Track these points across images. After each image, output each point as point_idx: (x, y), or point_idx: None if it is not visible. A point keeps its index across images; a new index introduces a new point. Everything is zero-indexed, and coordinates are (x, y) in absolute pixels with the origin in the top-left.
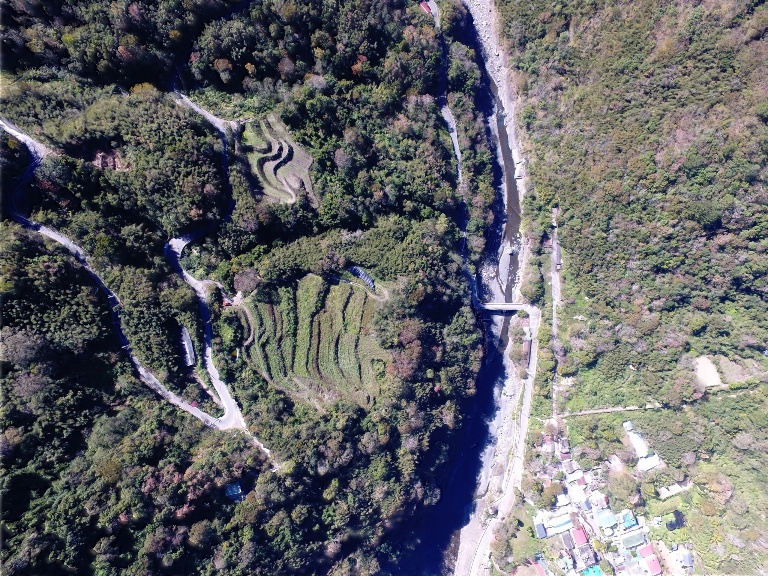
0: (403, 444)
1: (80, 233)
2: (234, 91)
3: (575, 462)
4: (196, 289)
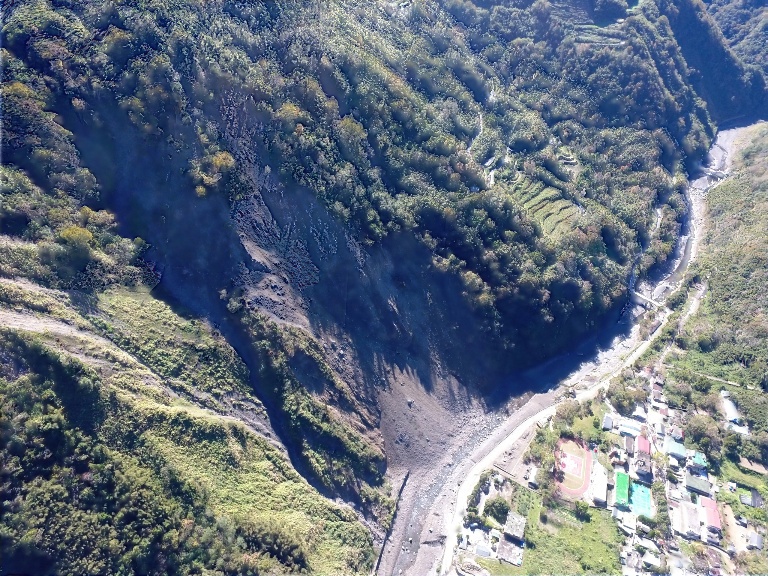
0: (556, 264)
1: (489, 112)
2: (564, 143)
3: (664, 397)
4: (505, 158)
